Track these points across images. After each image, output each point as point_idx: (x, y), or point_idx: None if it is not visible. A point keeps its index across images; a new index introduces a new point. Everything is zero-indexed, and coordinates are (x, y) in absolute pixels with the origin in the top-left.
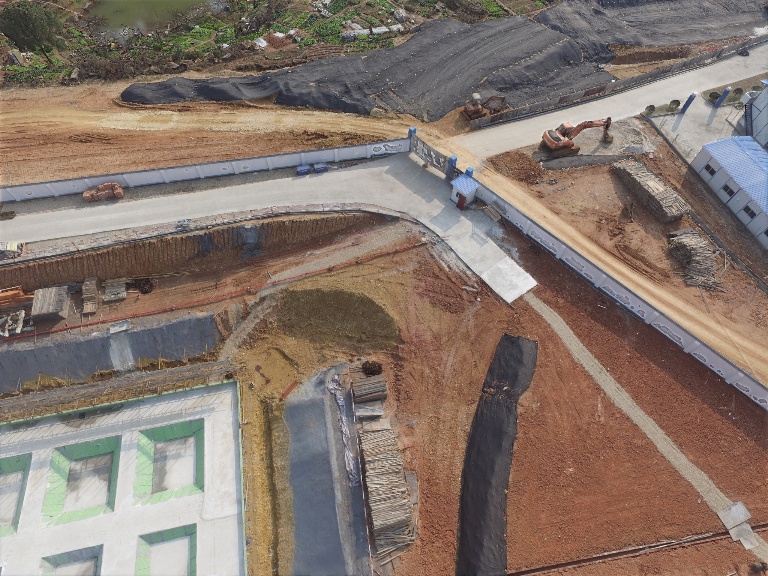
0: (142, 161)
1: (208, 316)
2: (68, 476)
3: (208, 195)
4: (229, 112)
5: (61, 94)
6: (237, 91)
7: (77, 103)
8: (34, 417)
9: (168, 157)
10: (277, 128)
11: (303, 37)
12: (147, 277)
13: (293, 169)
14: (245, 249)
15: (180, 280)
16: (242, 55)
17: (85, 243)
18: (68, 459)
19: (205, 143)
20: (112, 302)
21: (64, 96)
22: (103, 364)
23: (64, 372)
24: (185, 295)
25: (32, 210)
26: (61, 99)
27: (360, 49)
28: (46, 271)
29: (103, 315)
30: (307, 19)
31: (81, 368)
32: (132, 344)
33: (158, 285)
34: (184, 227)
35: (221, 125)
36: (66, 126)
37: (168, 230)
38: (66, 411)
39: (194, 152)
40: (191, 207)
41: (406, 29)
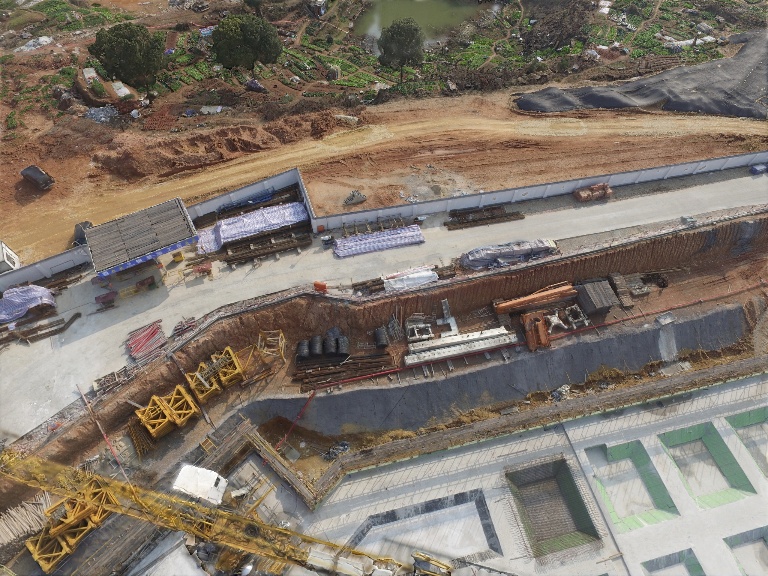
0: (594, 164)
1: (737, 307)
2: (675, 462)
3: (687, 194)
4: (628, 118)
5: (455, 104)
6: (627, 99)
7: (479, 112)
8: (623, 406)
9: (615, 160)
10: (688, 132)
11: (629, 49)
12: (657, 272)
13: (743, 169)
14: (738, 244)
15: (686, 274)
16: (587, 66)
17: (620, 239)
18: (665, 446)
19: (637, 147)
20: (641, 296)
21: (459, 106)
22: (653, 355)
23: (621, 363)
24: (701, 288)
25: (534, 210)
26: (460, 109)
27: (694, 59)
28: (584, 267)
29: (641, 308)
30: (617, 33)
31: (635, 359)
32: (676, 335)
33: (669, 279)
34: (694, 223)
35: (632, 130)
36: (489, 133)
37: (680, 226)
38: (648, 400)
39: (635, 155)
40: (681, 205)
41: (727, 40)
